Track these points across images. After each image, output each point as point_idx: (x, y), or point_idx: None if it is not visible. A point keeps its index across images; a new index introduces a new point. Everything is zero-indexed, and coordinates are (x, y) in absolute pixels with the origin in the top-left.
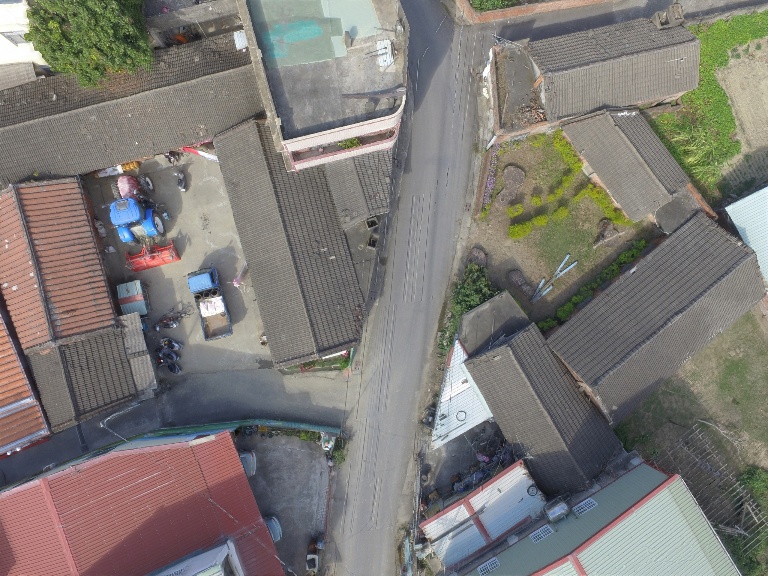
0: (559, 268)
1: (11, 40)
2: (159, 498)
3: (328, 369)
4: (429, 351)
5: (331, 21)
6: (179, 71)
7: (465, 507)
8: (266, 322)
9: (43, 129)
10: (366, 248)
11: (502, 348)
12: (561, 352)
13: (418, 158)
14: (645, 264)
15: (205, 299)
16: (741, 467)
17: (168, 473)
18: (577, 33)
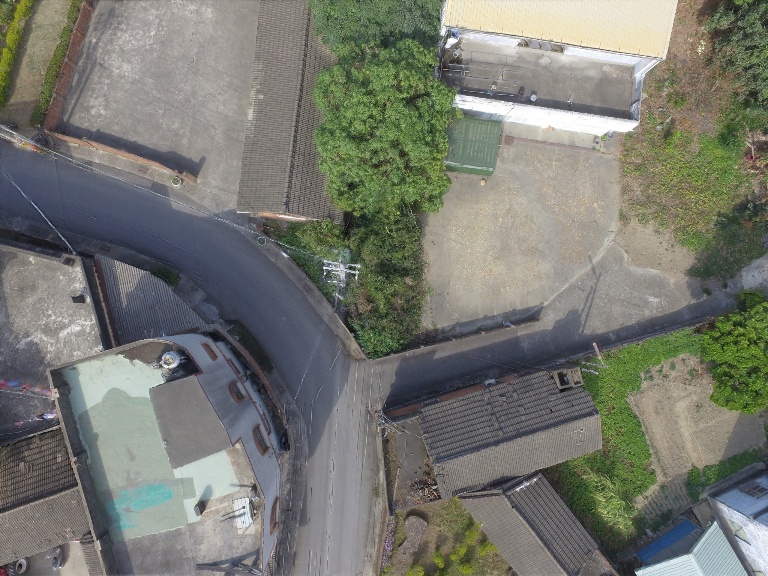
0: None
1: None
2: None
3: None
4: None
5: (182, 482)
6: (39, 476)
7: None
8: None
9: None
10: None
11: None
12: None
13: (314, 508)
14: None
15: None
16: None
17: None
18: (472, 395)
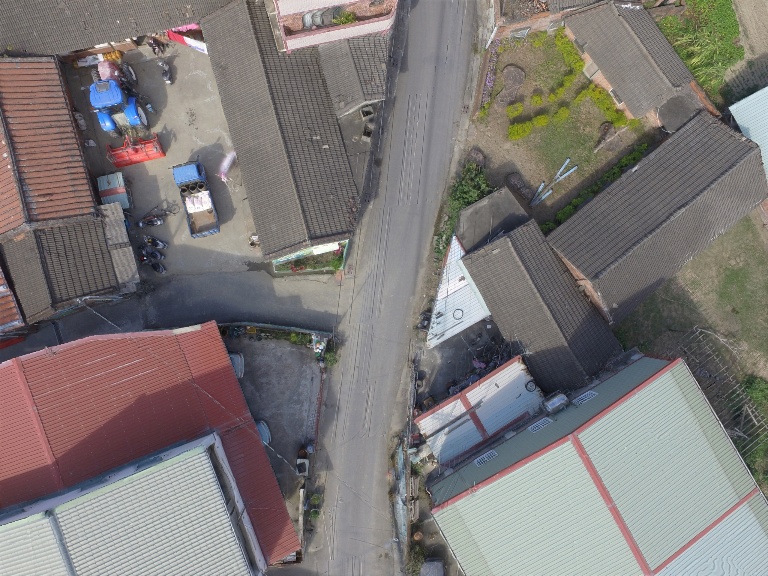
0: (559, 172)
1: None
2: (141, 385)
3: (320, 273)
4: (425, 255)
5: None
6: None
7: (462, 402)
8: (255, 212)
9: (17, 0)
10: (361, 140)
11: (501, 240)
12: (561, 249)
13: (415, 57)
14: (647, 162)
15: (191, 194)
16: (740, 377)
17: (151, 360)
18: None
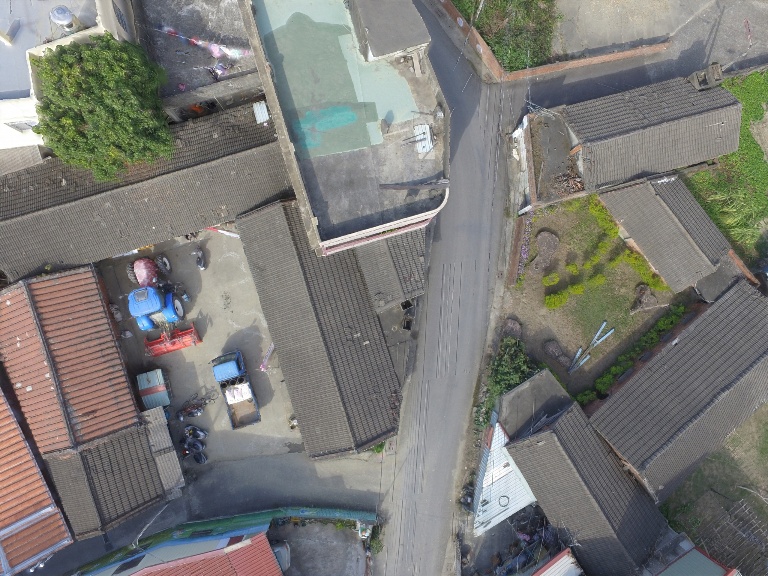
0: (596, 336)
1: (16, 128)
2: None
3: None
4: (465, 427)
5: (365, 106)
6: (197, 149)
7: None
8: (299, 413)
9: (53, 219)
10: (400, 329)
11: (546, 434)
12: (605, 432)
13: (447, 225)
14: (687, 335)
15: (231, 385)
16: None
17: None
18: (613, 95)
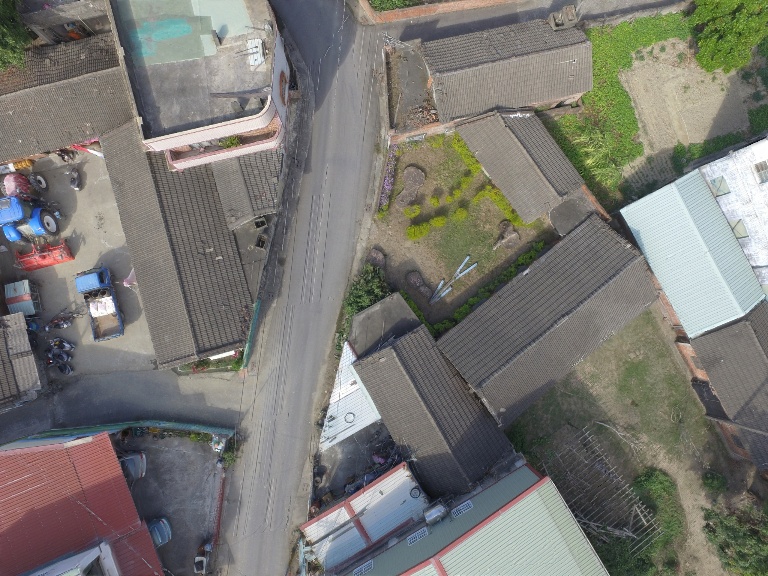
0: (458, 269)
1: None
2: (29, 500)
3: (224, 370)
4: (327, 352)
5: (201, 19)
6: (64, 69)
7: (346, 509)
8: (151, 323)
9: None
10: (256, 248)
11: (387, 350)
12: (450, 354)
13: (318, 158)
14: (538, 266)
15: (95, 299)
16: (639, 469)
17: (40, 475)
18: (472, 34)
